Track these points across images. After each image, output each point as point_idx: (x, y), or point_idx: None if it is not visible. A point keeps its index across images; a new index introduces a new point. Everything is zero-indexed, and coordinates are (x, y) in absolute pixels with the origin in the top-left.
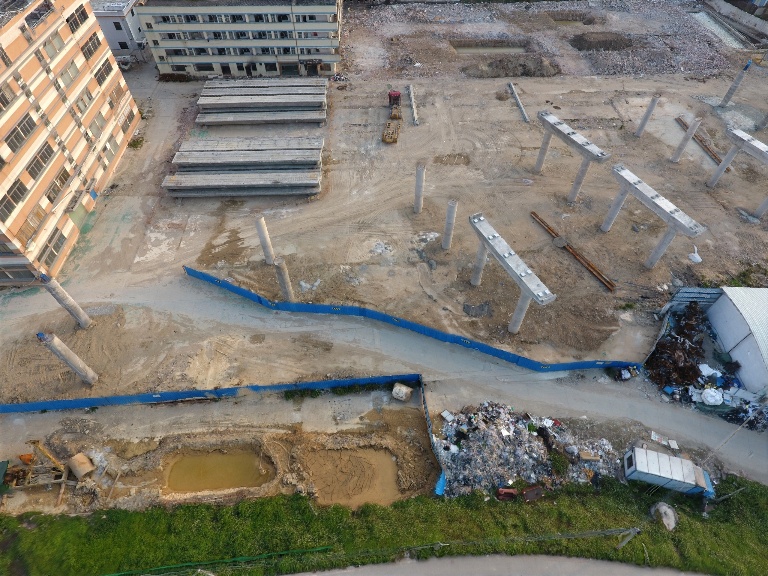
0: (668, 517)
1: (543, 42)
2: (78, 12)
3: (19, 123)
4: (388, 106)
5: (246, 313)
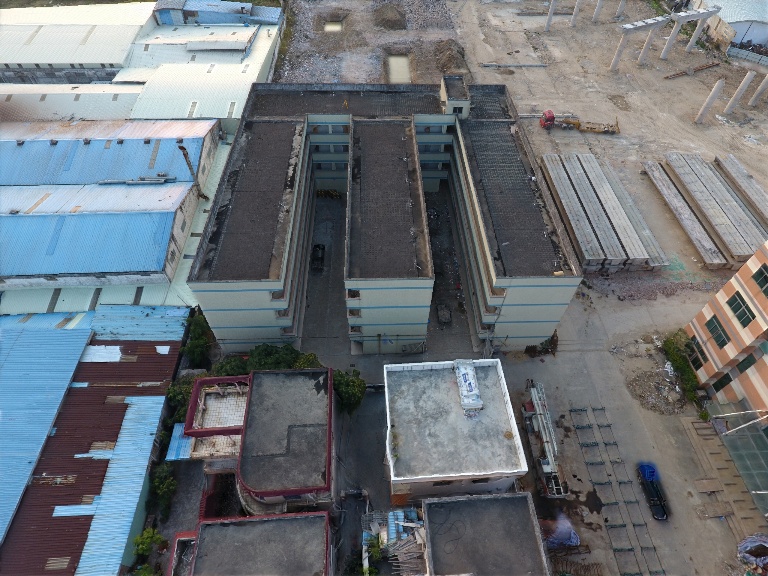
0: None
1: (392, 41)
2: None
3: None
4: (548, 131)
5: None
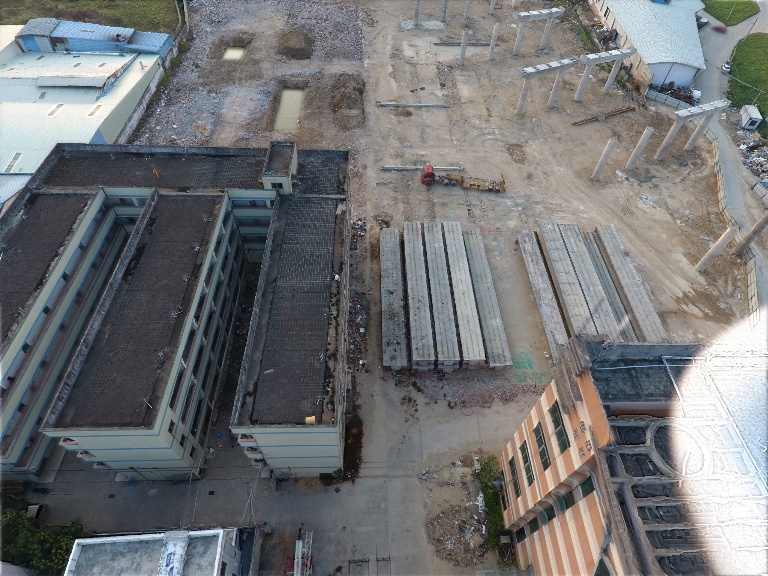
0: None
1: (289, 73)
2: None
3: None
4: (428, 187)
5: (762, 279)
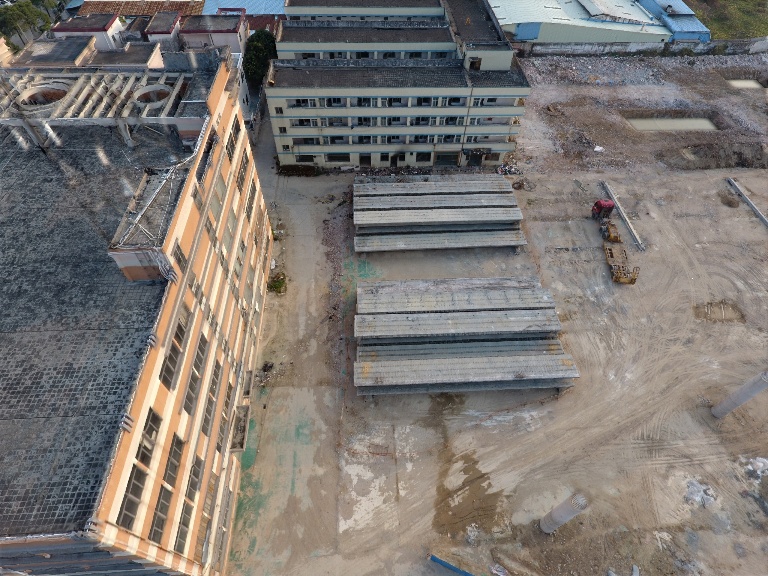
0: None
1: (735, 114)
2: (233, 127)
3: None
4: (591, 217)
5: None
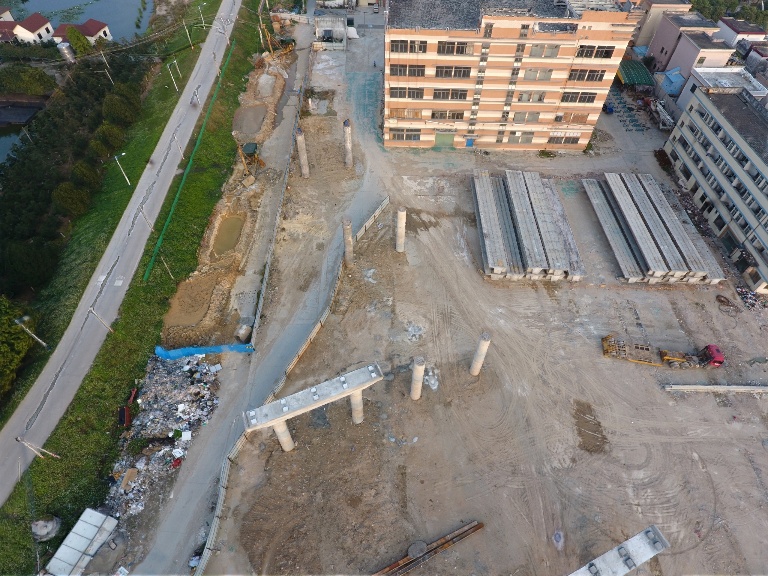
0: (42, 527)
1: None
2: (603, 49)
3: (457, 67)
4: None
5: None
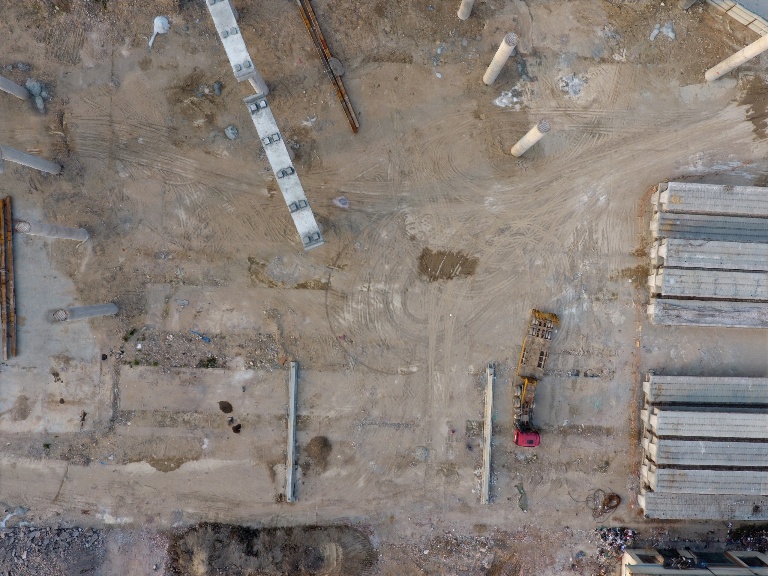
0: None
1: None
2: None
3: None
4: None
5: None
